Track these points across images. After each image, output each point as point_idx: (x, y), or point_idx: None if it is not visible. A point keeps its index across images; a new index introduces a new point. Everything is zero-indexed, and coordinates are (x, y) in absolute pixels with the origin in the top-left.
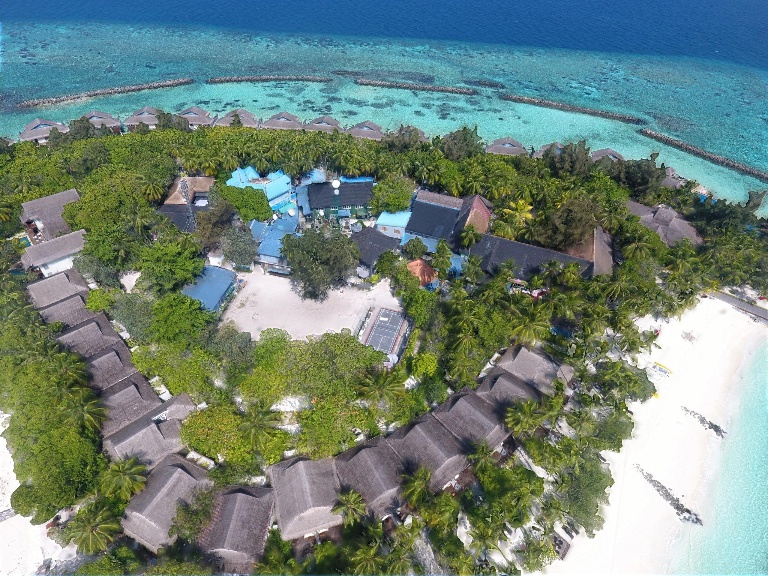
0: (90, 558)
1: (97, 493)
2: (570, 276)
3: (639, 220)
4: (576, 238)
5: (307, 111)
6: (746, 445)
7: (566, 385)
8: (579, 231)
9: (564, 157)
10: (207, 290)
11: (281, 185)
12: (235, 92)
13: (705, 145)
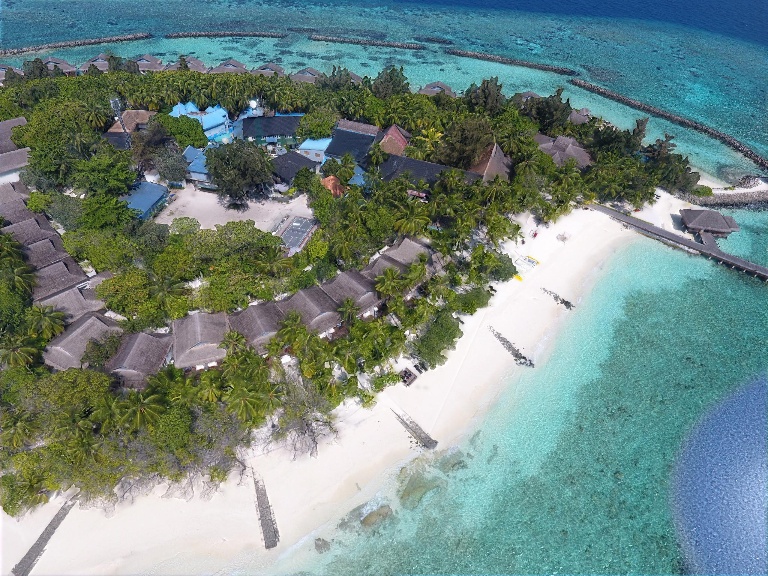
0: (10, 368)
1: (23, 334)
2: (453, 180)
3: (537, 146)
4: (471, 155)
5: (258, 62)
6: (589, 315)
7: (440, 268)
8: (470, 147)
9: (479, 93)
10: (139, 200)
11: (217, 117)
12: (191, 46)
13: (629, 93)
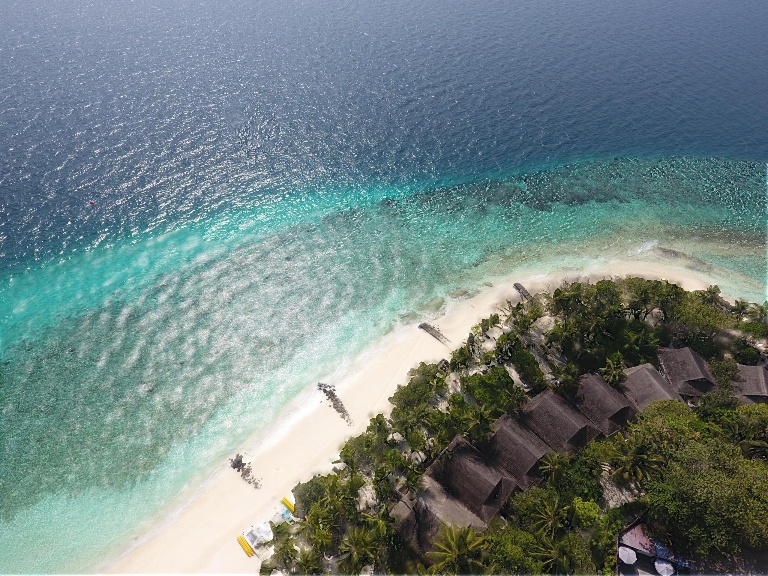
0: None
1: None
2: None
3: None
4: None
5: None
6: (219, 447)
7: (404, 496)
8: None
9: None
10: None
11: None
12: None
13: None
